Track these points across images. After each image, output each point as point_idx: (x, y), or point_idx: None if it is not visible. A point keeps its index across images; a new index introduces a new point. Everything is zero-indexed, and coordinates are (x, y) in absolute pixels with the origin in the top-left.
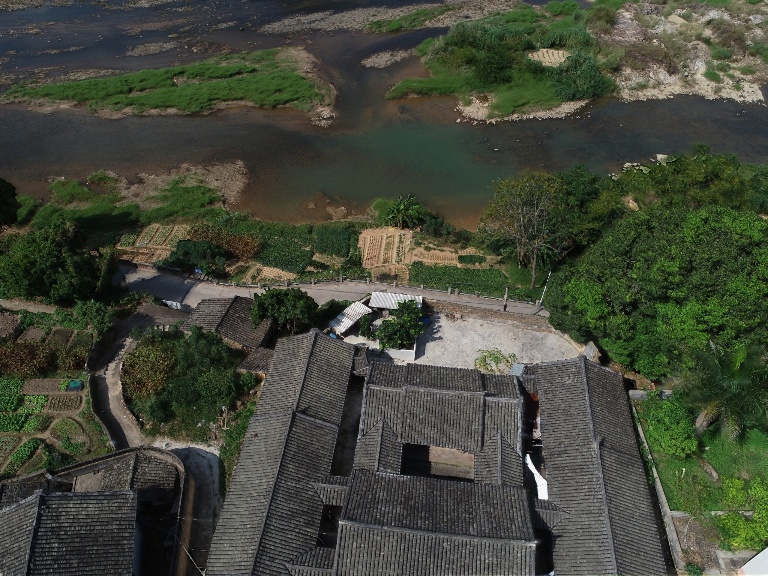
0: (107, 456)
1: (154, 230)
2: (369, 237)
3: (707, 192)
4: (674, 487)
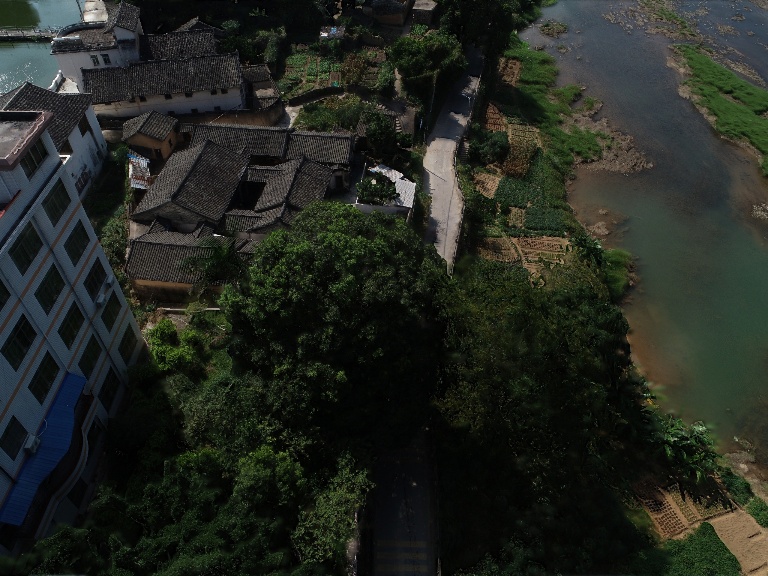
0: None
1: (530, 130)
2: (560, 243)
3: (473, 305)
4: (212, 320)
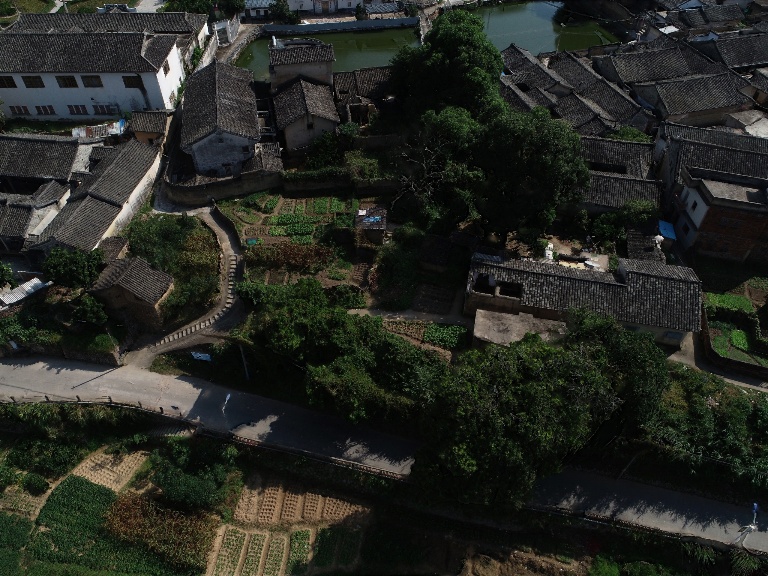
0: (210, 184)
1: (266, 575)
2: None
3: None
4: None
